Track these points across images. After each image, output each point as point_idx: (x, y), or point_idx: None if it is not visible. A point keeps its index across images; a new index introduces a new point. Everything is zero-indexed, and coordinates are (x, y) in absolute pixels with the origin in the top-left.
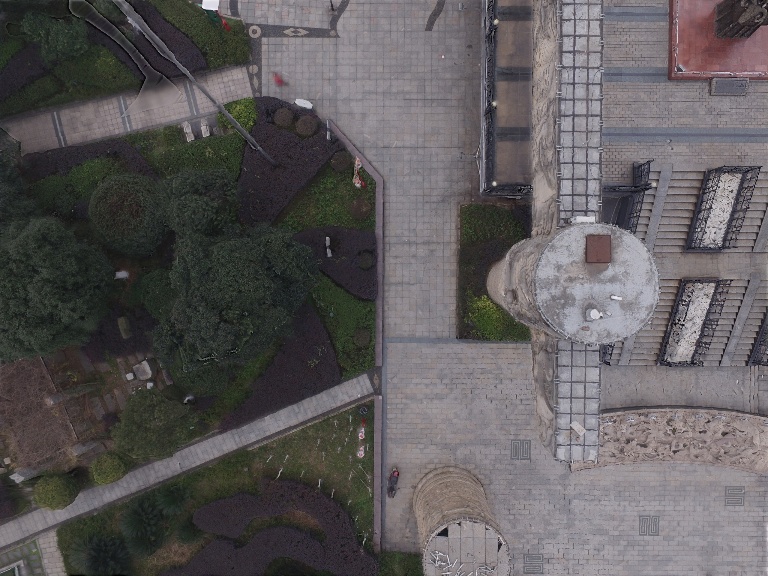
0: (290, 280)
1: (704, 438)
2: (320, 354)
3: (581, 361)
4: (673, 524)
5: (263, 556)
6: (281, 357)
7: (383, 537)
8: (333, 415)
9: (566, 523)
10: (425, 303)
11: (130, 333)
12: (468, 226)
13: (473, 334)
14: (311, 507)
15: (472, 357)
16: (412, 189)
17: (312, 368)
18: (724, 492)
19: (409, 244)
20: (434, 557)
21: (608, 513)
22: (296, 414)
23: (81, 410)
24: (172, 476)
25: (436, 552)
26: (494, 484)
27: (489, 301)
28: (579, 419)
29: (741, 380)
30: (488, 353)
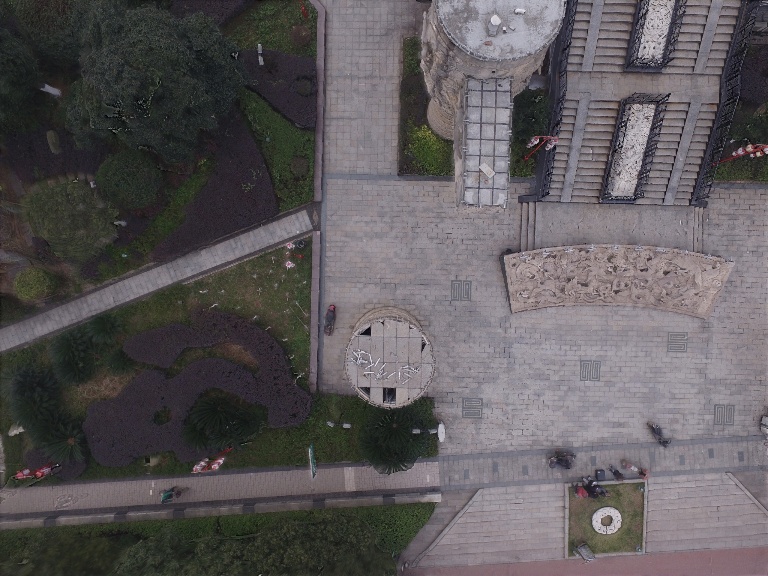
0: (214, 71)
1: (645, 276)
2: (255, 178)
3: (491, 102)
4: (614, 370)
5: (194, 386)
6: (214, 178)
7: (320, 378)
8: (271, 251)
9: (506, 367)
10: (366, 139)
11: (59, 148)
12: (410, 57)
13: (413, 166)
14: (244, 337)
15: (413, 195)
16: (355, 22)
17: (247, 193)
18: (667, 338)
19: (351, 78)
20: (356, 355)
21: (549, 357)
22: (233, 249)
23: (5, 218)
24: (105, 310)
25: (358, 350)
26: (434, 326)
27: (429, 131)
28: (488, 162)
29: (685, 220)
30: (430, 191)
